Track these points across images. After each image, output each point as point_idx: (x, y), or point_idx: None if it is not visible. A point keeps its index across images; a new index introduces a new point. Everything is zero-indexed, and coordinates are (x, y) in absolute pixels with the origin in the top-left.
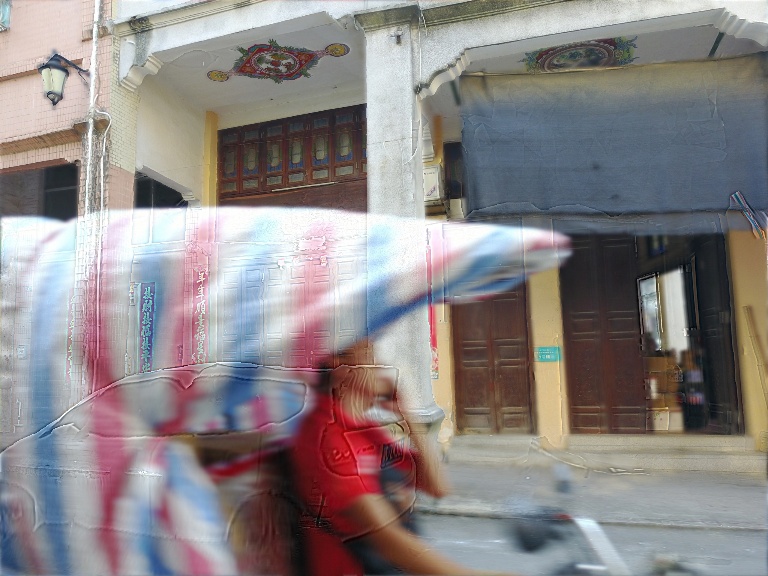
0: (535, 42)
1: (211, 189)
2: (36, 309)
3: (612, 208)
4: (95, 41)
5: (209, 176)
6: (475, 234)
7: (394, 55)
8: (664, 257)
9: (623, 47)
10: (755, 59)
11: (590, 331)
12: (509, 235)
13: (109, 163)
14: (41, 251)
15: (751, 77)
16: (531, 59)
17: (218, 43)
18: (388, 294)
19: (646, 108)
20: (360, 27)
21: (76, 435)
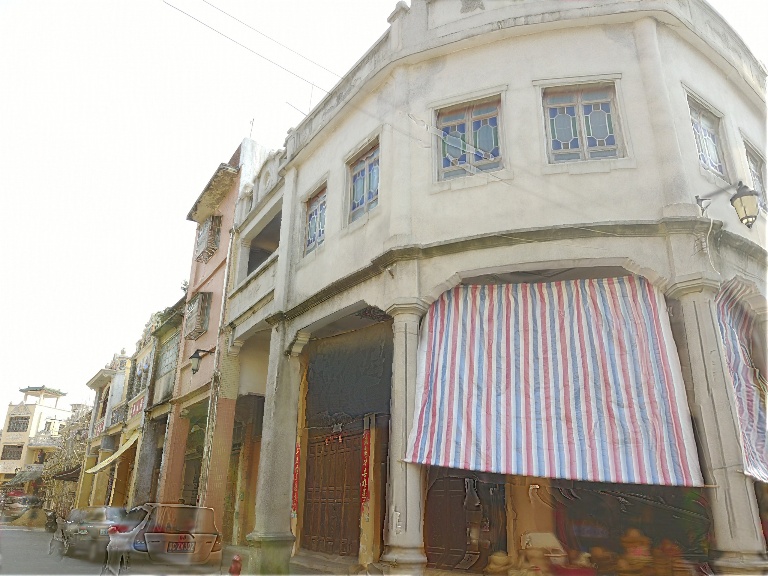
0: (317, 324)
1: (304, 395)
2: (249, 470)
3: (351, 414)
4: (218, 337)
5: (304, 387)
6: None
7: (276, 338)
8: None
9: None
10: None
11: (442, 489)
12: None
13: (218, 397)
14: (254, 435)
15: None
16: (365, 316)
17: (253, 330)
18: (262, 468)
19: (357, 354)
20: None
21: (114, 531)
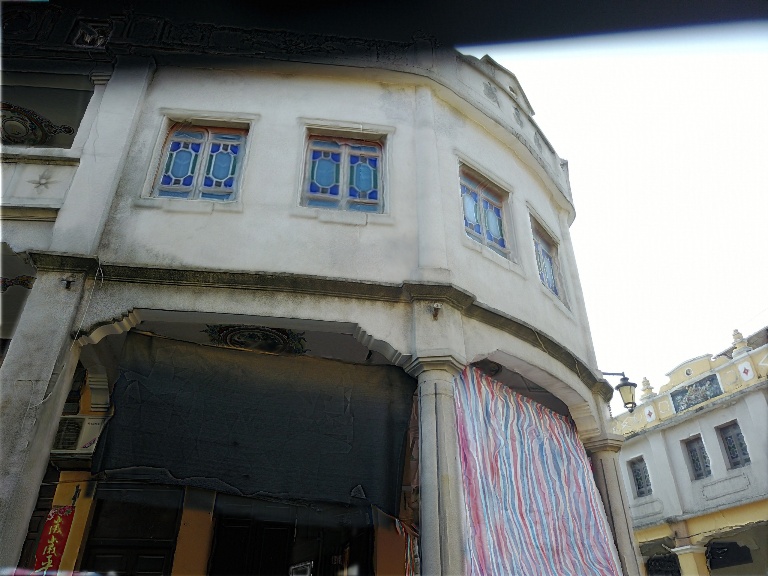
0: (201, 316)
1: None
2: None
3: (246, 486)
4: None
5: None
6: (133, 498)
7: (59, 298)
8: (320, 545)
9: (295, 338)
10: (384, 369)
11: None
12: (169, 504)
13: None
14: None
15: (380, 384)
16: (213, 331)
17: None
18: None
19: (291, 394)
20: (33, 265)
21: None
